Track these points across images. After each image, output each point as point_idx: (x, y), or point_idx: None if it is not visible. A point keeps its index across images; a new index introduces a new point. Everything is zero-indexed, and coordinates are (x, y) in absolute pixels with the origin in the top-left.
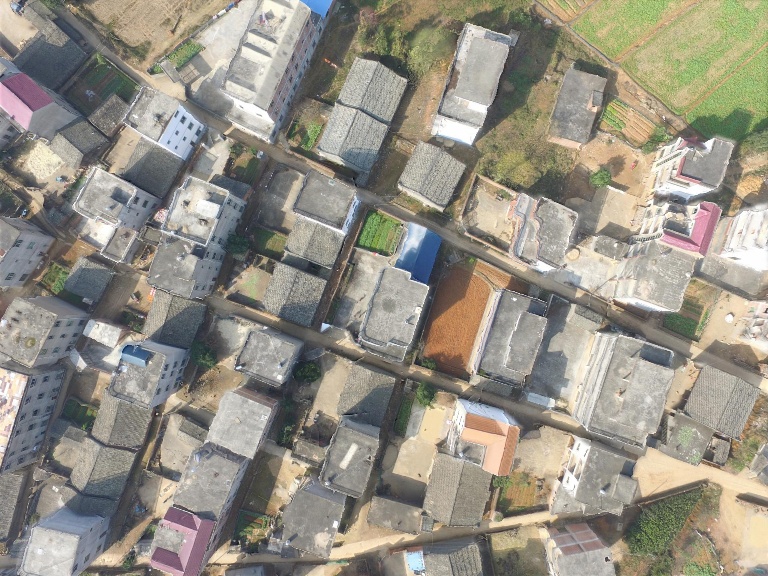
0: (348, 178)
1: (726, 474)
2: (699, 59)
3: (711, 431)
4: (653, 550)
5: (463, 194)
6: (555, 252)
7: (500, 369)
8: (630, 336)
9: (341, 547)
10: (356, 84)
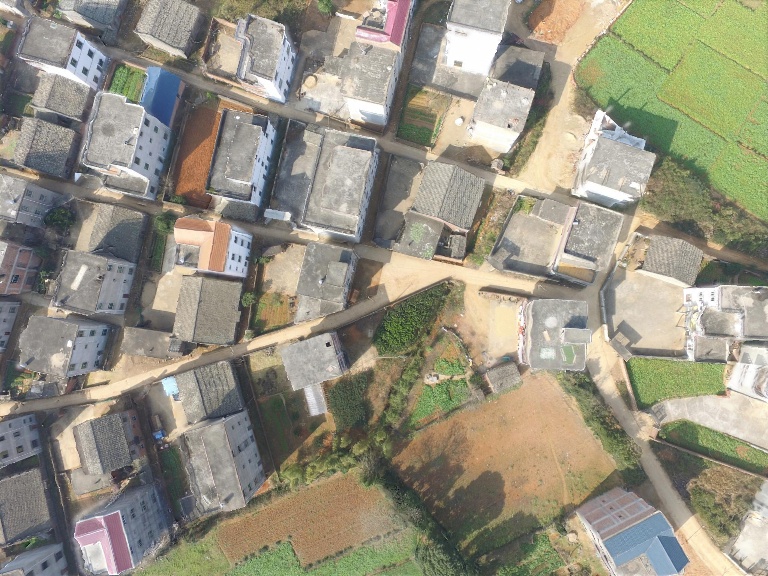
0: (95, 37)
1: (468, 270)
2: None
3: (441, 225)
4: (400, 349)
5: None
6: (267, 65)
7: (229, 185)
8: None
9: (107, 386)
10: None
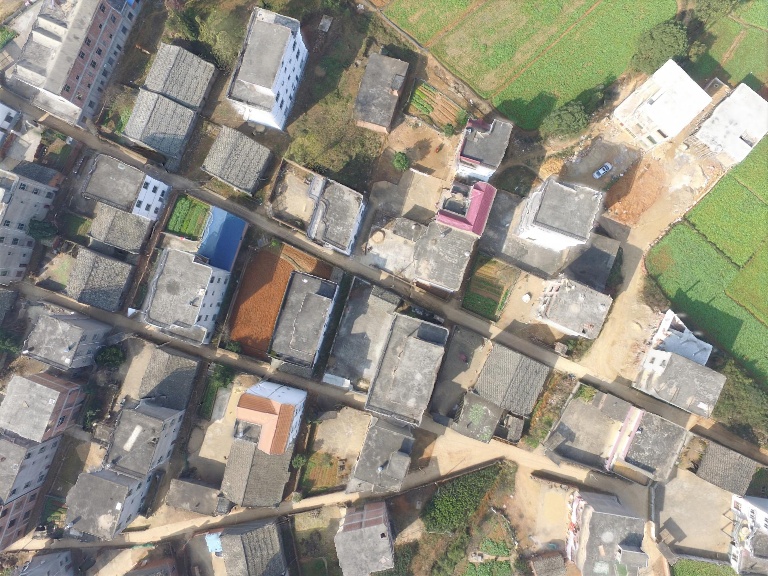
0: (158, 163)
1: (522, 451)
2: (505, 43)
3: (501, 409)
4: (448, 527)
5: (274, 178)
6: (341, 233)
7: (291, 350)
8: (430, 317)
9: (147, 531)
10: (160, 69)
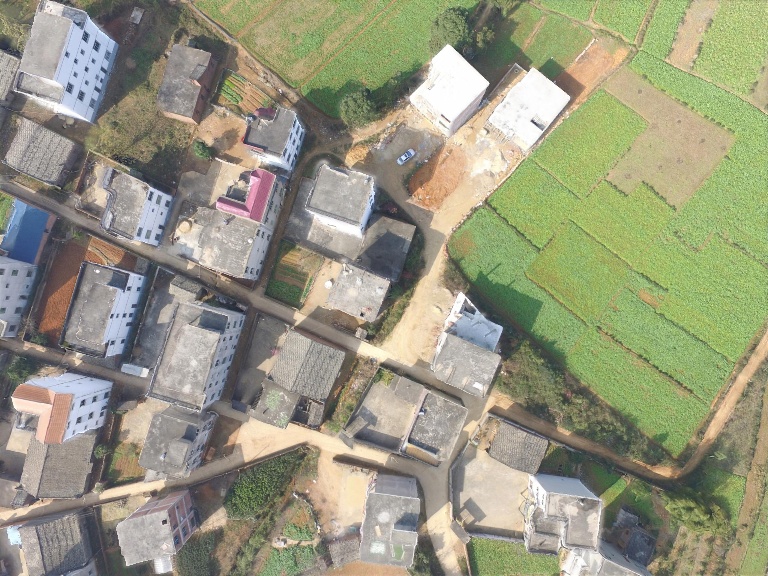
0: None
1: (324, 436)
2: (314, 33)
3: (297, 394)
4: (249, 513)
5: None
6: (129, 223)
7: (83, 341)
8: (233, 305)
9: None
10: None
